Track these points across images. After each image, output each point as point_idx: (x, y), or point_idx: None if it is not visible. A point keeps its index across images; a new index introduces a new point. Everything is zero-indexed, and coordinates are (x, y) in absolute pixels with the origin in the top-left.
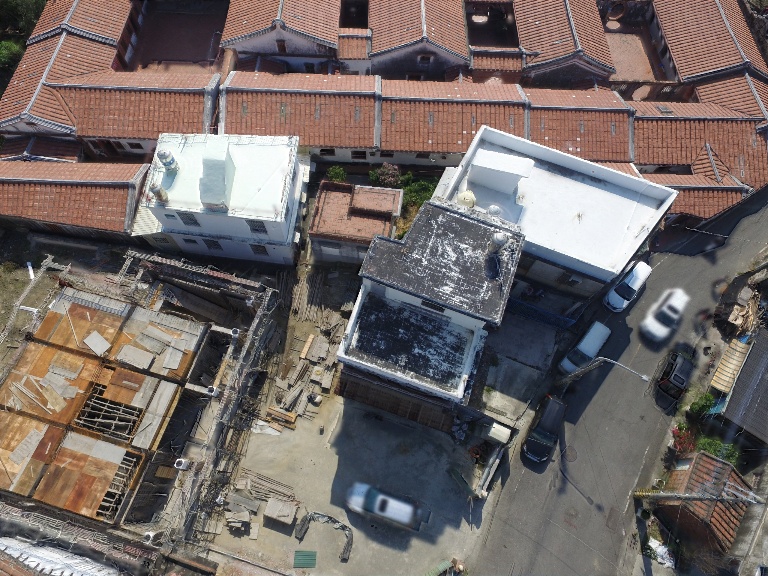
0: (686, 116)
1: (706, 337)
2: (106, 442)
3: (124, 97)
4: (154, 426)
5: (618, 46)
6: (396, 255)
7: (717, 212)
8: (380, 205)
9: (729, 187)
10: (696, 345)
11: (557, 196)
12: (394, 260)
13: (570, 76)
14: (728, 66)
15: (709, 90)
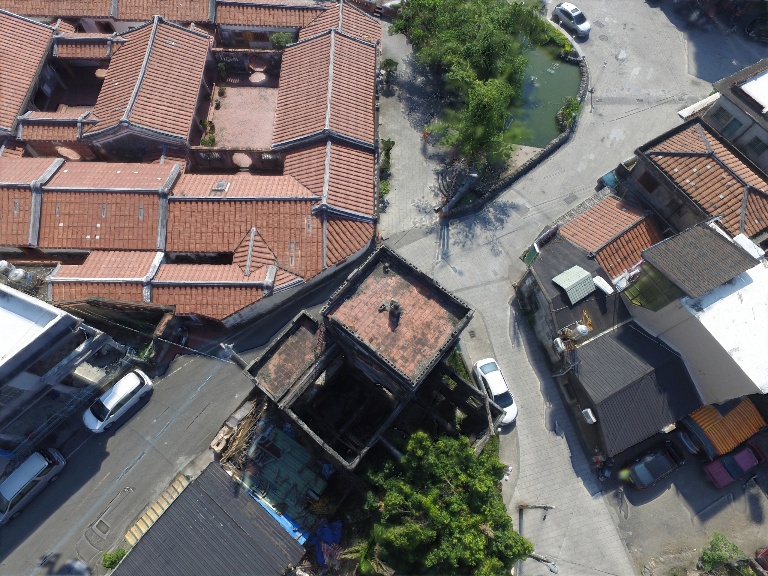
0: (235, 195)
1: (195, 462)
2: None
3: None
4: None
5: (252, 102)
6: None
7: (232, 312)
8: None
9: (246, 283)
10: (178, 473)
11: None
12: None
13: (142, 145)
14: (311, 134)
15: (294, 160)
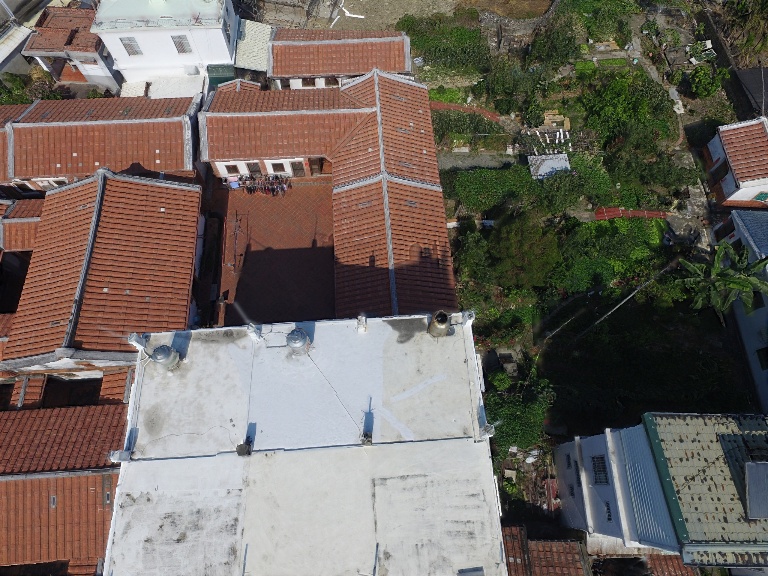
0: None
1: None
2: None
3: (294, 109)
4: None
5: None
6: None
7: None
8: (47, 39)
9: None
10: None
11: None
12: None
13: None
14: None
15: None
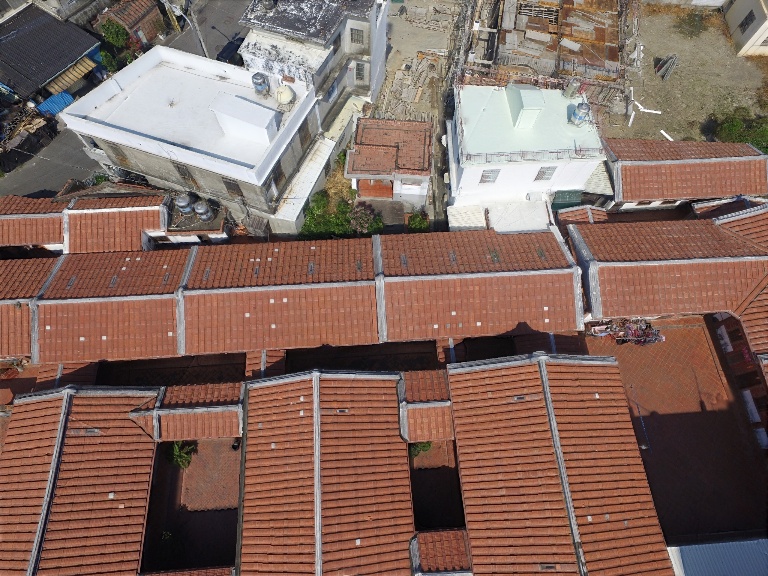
0: None
1: None
2: (534, 1)
3: (687, 254)
4: (507, 7)
5: None
6: (350, 5)
7: None
8: (367, 158)
9: None
10: None
11: (188, 122)
12: (351, 1)
13: None
14: None
15: None
